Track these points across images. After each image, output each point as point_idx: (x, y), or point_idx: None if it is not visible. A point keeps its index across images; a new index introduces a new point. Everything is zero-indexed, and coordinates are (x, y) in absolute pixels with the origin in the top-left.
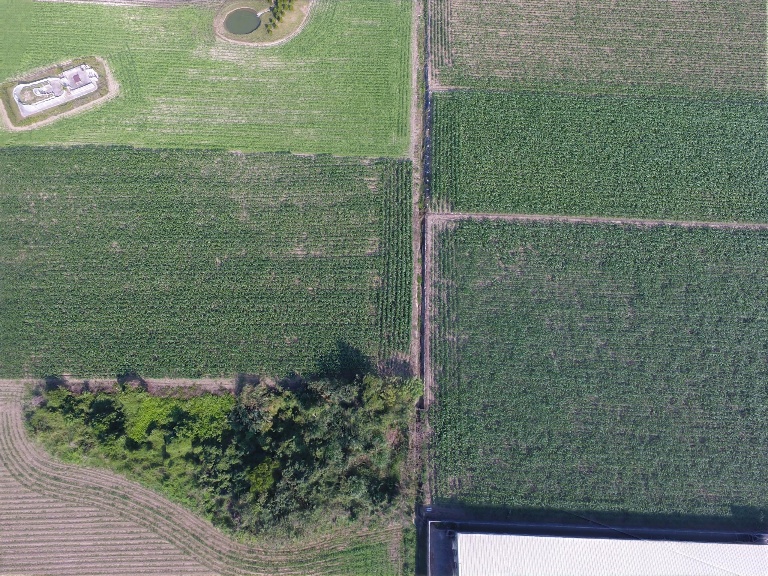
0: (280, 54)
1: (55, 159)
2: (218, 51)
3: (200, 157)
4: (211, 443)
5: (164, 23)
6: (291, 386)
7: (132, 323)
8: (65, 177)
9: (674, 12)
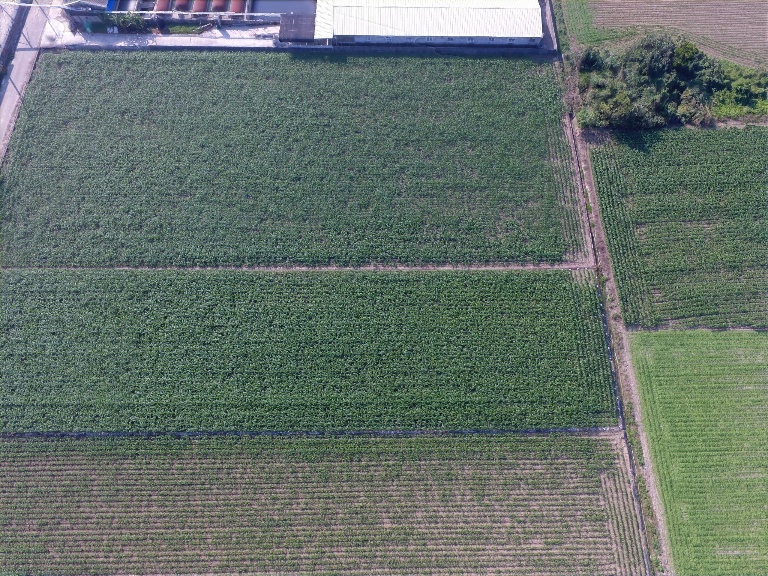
0: None
1: None
2: None
3: None
4: (719, 87)
5: None
6: (674, 125)
7: None
8: None
9: None
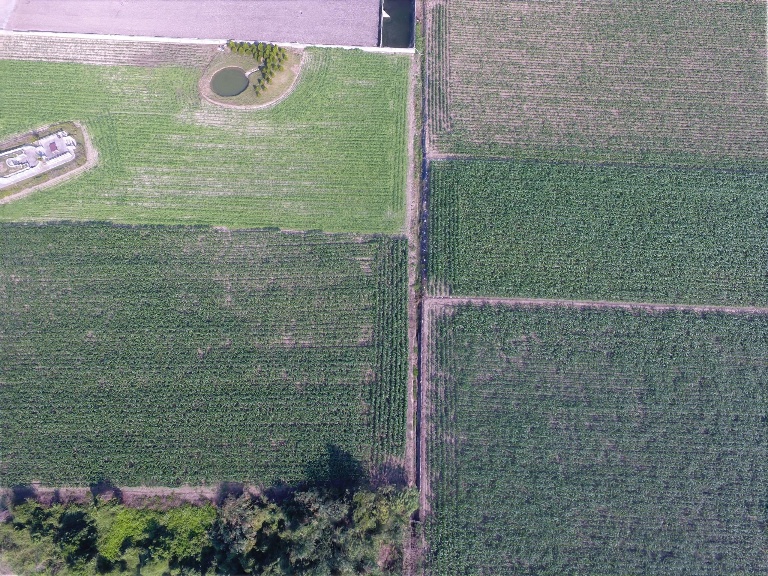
0: (269, 118)
1: (28, 237)
2: (203, 115)
3: (183, 235)
4: (190, 563)
5: (147, 84)
6: (277, 495)
7: (107, 424)
8: (38, 258)
9: (685, 70)
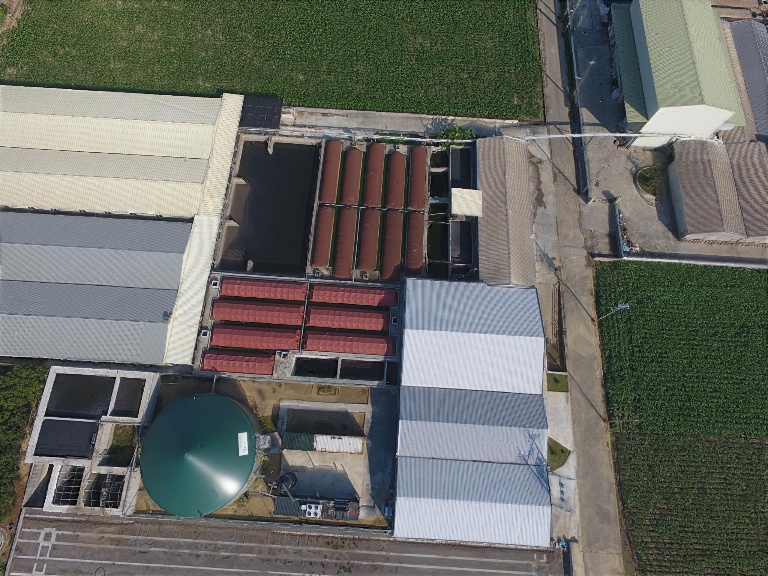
0: None
1: None
2: None
3: None
4: None
5: None
6: None
7: None
8: None
9: None
